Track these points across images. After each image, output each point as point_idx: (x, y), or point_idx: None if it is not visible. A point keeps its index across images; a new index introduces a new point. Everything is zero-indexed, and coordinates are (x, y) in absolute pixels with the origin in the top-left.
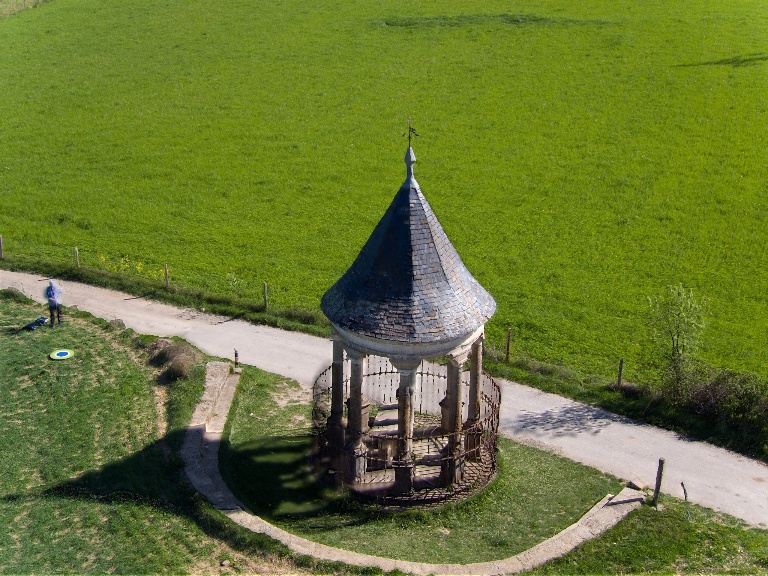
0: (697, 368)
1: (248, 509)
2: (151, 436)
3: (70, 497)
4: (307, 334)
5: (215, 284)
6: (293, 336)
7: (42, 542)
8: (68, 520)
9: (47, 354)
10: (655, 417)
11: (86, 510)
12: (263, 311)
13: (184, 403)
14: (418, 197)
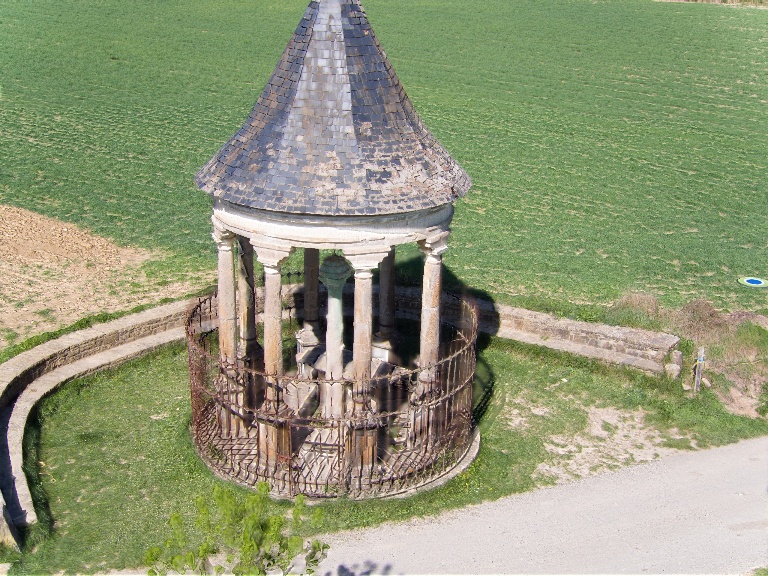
0: None
1: None
2: None
3: None
4: None
5: None
6: None
7: None
8: None
9: None
10: None
11: None
12: None
13: None
14: None
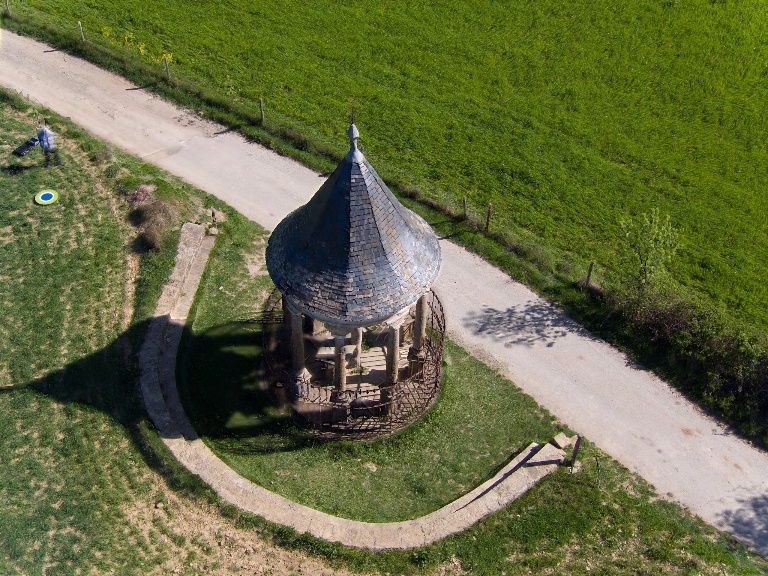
0: (661, 291)
1: (193, 430)
2: (116, 328)
3: (33, 404)
4: (298, 163)
5: (218, 75)
6: (284, 165)
7: (2, 462)
8: (27, 437)
9: (33, 194)
10: (611, 333)
11: (45, 424)
12: (259, 125)
13: (151, 287)
14: (360, 172)
